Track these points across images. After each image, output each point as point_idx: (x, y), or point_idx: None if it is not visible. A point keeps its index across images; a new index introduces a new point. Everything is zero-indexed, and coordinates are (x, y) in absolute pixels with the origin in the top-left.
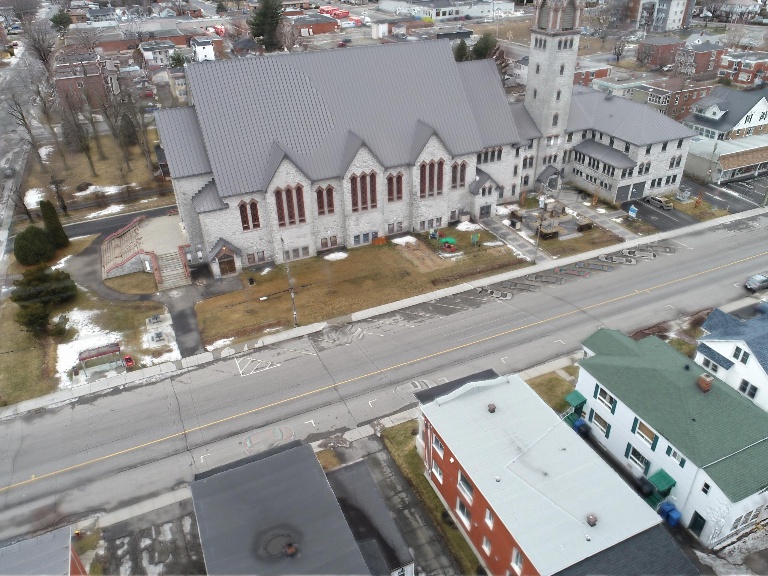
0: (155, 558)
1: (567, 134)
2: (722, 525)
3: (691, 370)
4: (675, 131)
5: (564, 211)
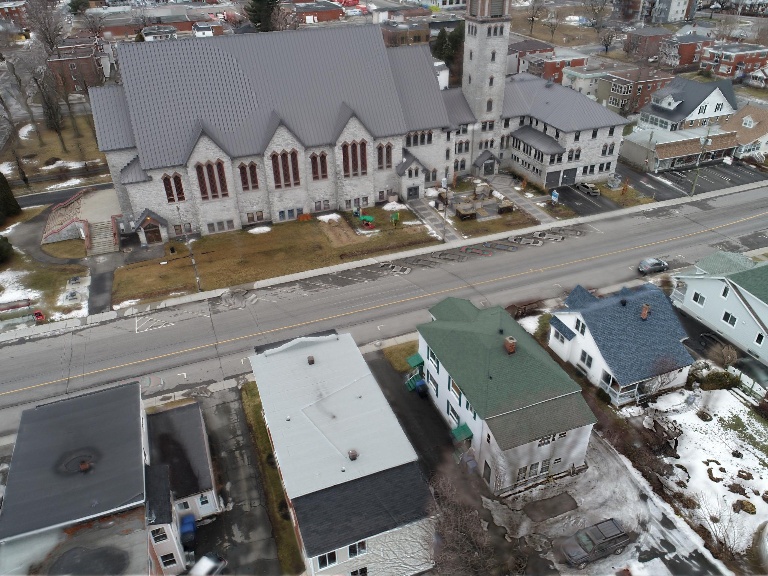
0: None
1: (503, 120)
2: (503, 473)
3: (505, 334)
4: (606, 119)
5: (492, 195)
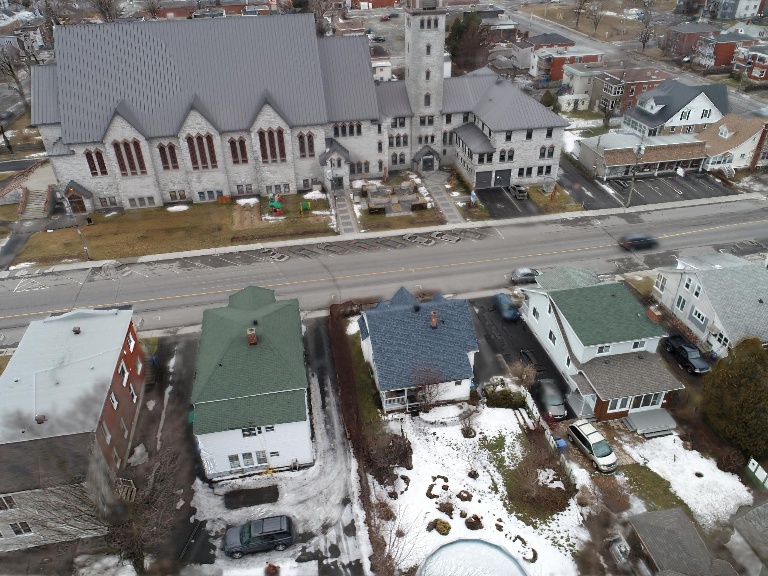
0: None
1: (444, 115)
2: (209, 458)
3: (259, 326)
4: (542, 119)
5: (417, 191)
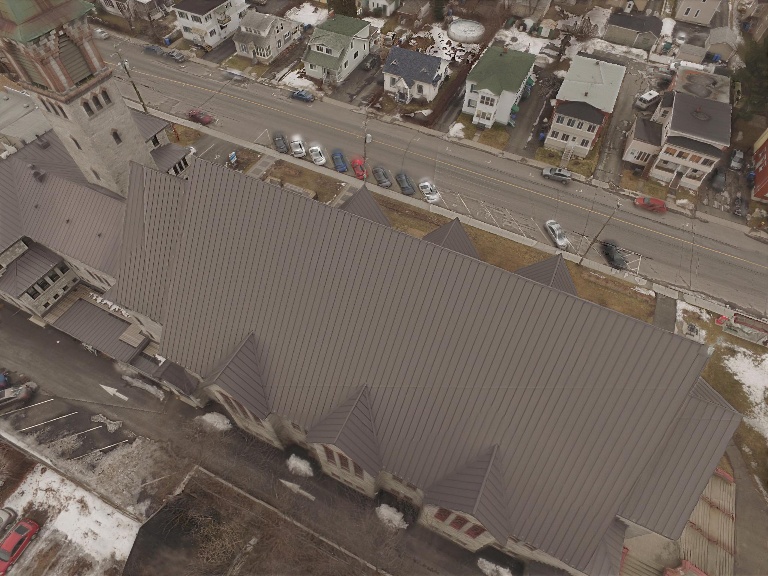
0: (724, 198)
1: None
2: None
3: None
4: None
5: None
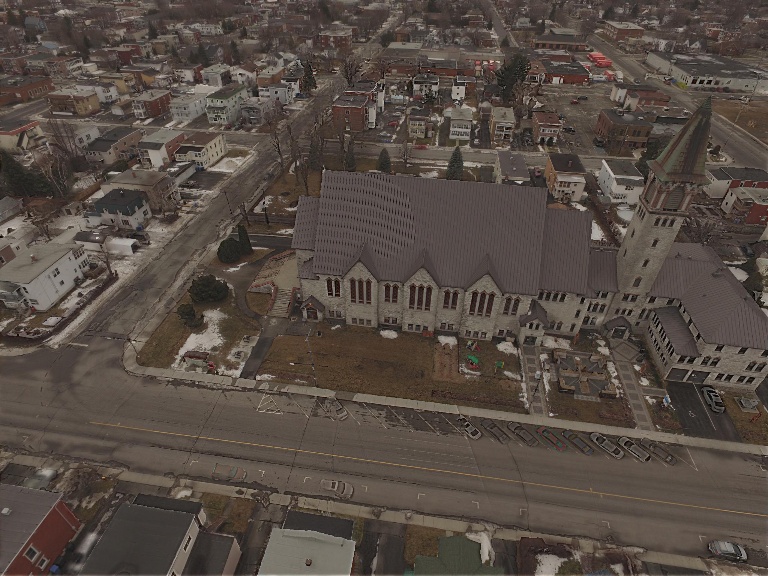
0: None
1: (649, 296)
2: None
3: None
4: (763, 340)
5: (606, 367)
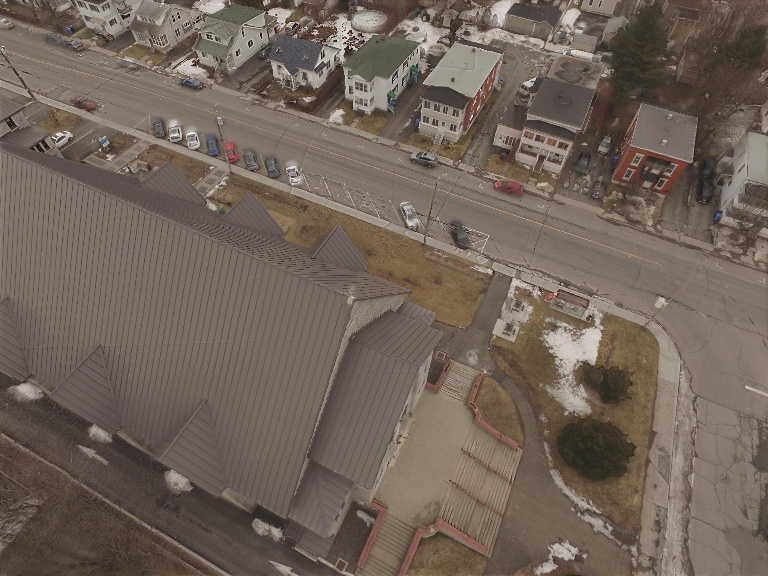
0: (585, 181)
1: None
2: None
3: None
4: None
5: None
